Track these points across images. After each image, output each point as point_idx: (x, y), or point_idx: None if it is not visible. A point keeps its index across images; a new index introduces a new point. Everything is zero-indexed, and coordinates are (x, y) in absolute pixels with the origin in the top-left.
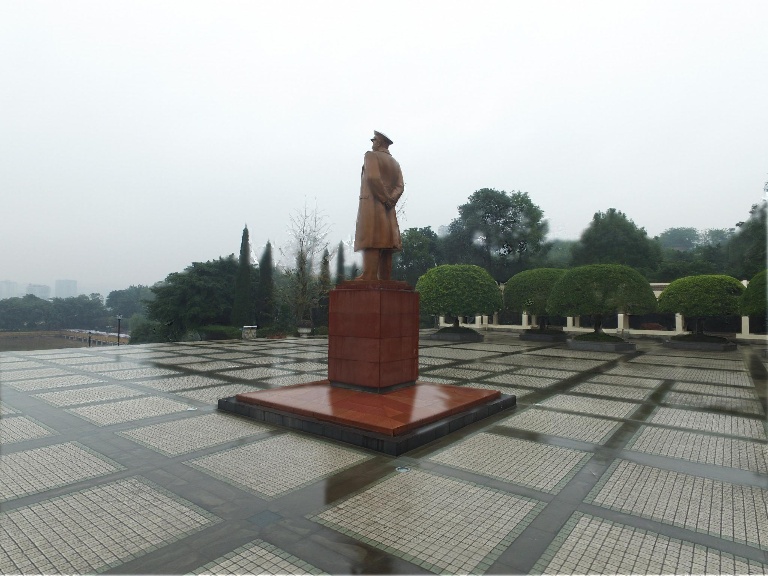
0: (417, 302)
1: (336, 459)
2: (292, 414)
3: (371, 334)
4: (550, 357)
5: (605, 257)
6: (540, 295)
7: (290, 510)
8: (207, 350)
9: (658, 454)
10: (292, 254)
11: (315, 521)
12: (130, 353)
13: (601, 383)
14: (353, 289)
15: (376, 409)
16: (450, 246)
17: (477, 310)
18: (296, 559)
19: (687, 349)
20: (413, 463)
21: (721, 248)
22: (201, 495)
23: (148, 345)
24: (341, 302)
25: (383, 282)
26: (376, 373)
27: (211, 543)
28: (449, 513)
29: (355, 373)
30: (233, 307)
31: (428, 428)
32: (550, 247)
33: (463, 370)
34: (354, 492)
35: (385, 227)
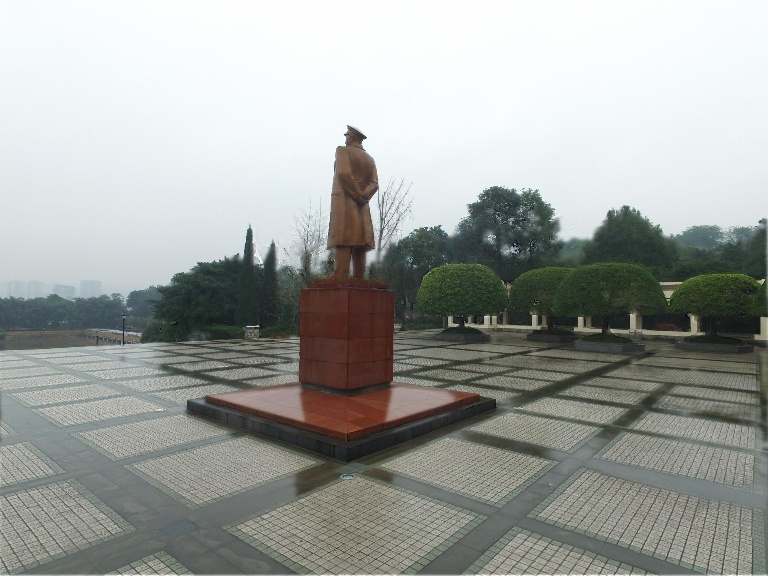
0: (391, 301)
1: (283, 464)
2: (254, 416)
3: (339, 334)
4: (551, 358)
5: (618, 256)
6: (547, 295)
7: (210, 520)
8: (204, 350)
9: (628, 464)
10: (297, 254)
11: (231, 532)
12: (127, 352)
13: (595, 386)
14: (323, 288)
15: (338, 412)
16: (459, 245)
17: (481, 310)
18: (191, 575)
19: (700, 351)
20: (361, 470)
21: (740, 246)
22: (126, 501)
23: (149, 344)
24: (311, 301)
25: (353, 281)
26: (344, 375)
27: (111, 555)
28: (376, 526)
29: (324, 374)
30: (237, 307)
31: (387, 433)
32: (562, 246)
33: (455, 371)
34: (286, 501)
35: (356, 224)
